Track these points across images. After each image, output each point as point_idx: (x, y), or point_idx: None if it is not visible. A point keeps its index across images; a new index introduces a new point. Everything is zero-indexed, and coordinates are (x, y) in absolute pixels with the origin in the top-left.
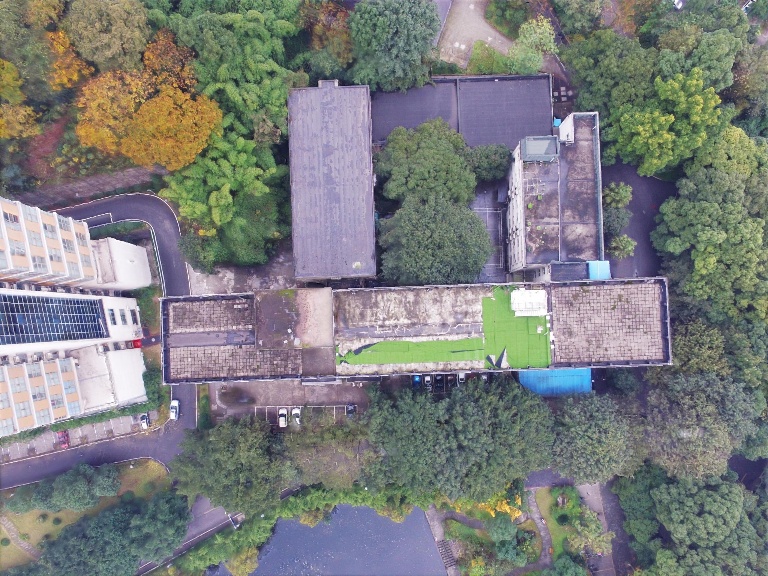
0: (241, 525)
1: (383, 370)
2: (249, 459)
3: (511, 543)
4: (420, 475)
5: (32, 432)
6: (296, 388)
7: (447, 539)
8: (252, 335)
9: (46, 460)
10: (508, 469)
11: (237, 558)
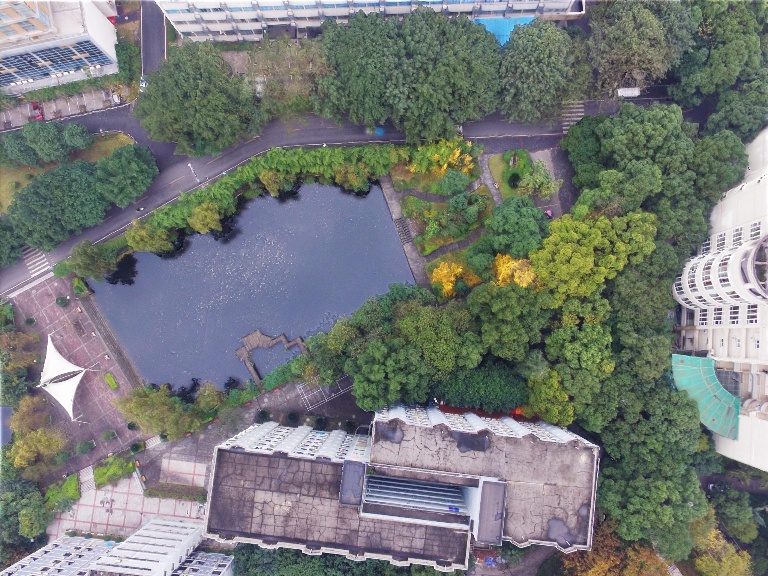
0: None
1: None
2: (208, 67)
3: (463, 193)
4: (370, 83)
5: (8, 96)
6: None
7: (404, 215)
8: None
9: None
10: (454, 75)
11: (198, 206)
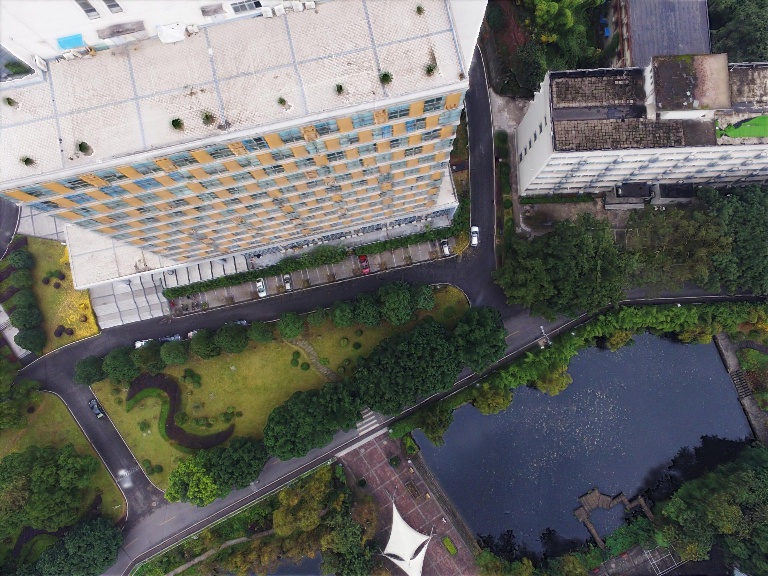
0: (546, 346)
1: (764, 142)
2: (606, 246)
3: None
4: None
5: (341, 252)
6: (599, 212)
7: (743, 368)
8: (632, 110)
9: (345, 286)
10: None
11: (555, 371)
